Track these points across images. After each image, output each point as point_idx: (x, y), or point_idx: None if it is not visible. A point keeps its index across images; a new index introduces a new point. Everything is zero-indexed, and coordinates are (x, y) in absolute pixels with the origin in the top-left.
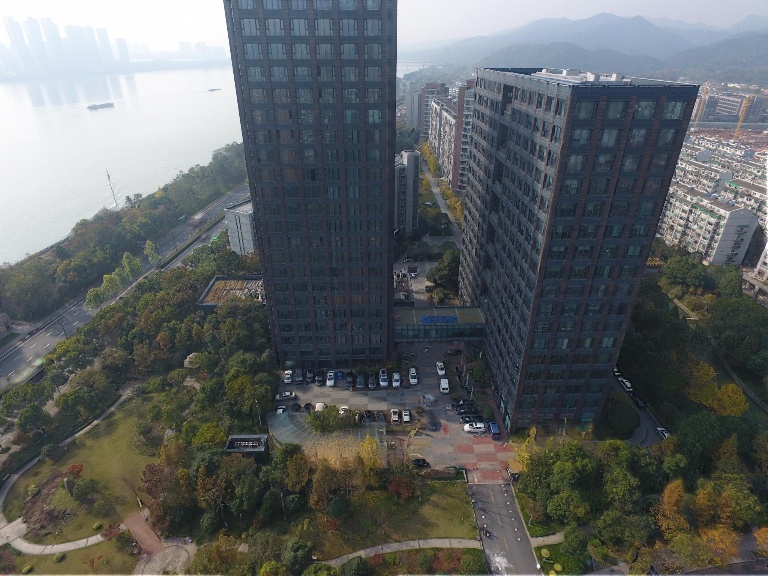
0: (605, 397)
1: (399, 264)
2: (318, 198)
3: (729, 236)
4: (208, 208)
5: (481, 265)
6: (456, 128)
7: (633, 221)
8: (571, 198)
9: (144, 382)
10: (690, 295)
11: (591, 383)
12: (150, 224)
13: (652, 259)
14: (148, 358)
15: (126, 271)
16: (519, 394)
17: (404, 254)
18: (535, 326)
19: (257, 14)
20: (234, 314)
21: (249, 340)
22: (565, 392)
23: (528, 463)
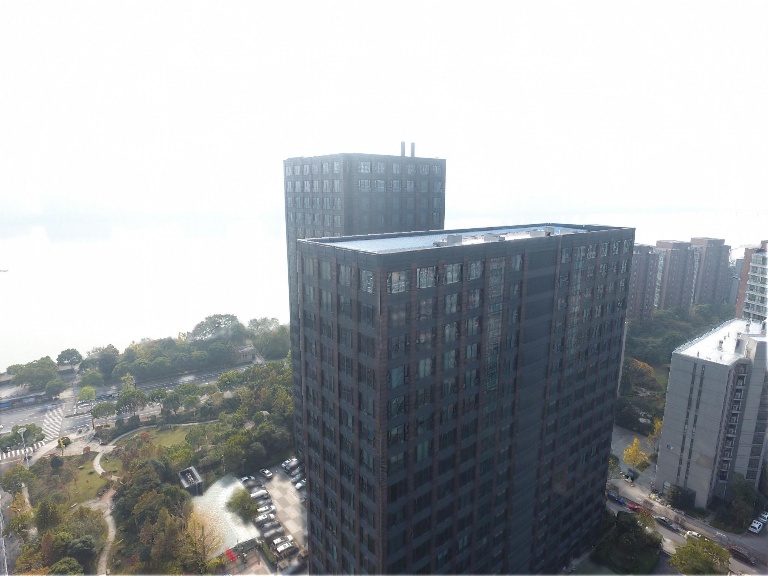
0: None
1: None
2: None
3: None
4: None
5: None
6: None
7: (360, 415)
8: None
9: None
10: None
11: None
12: None
13: None
14: (245, 400)
15: None
16: None
17: None
18: None
19: None
20: None
21: None
22: None
23: None
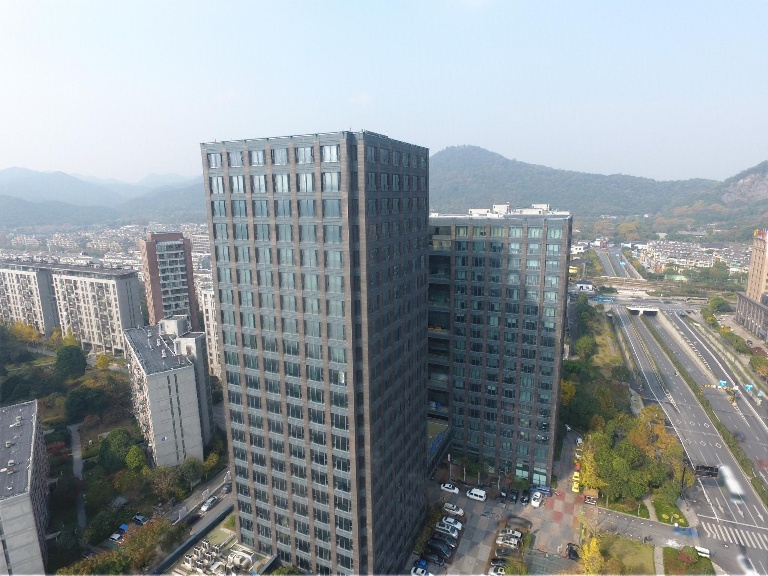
0: None
1: None
2: (400, 359)
3: None
4: None
5: None
6: (150, 286)
7: None
8: None
9: None
10: None
11: None
12: None
13: None
14: None
15: None
16: None
17: None
18: None
19: (377, 168)
20: None
21: None
22: None
23: (603, 480)
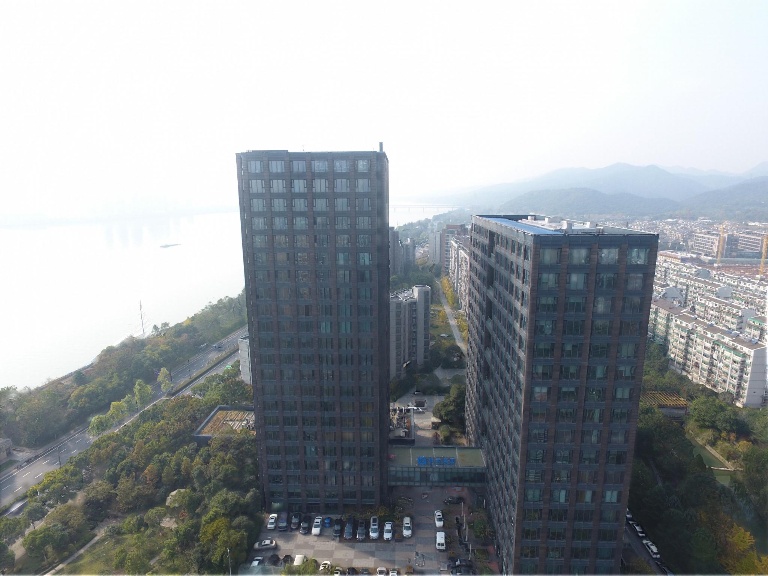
0: (619, 565)
1: (407, 397)
2: (311, 332)
3: (759, 376)
4: (230, 337)
5: (481, 402)
6: None
7: (616, 362)
8: (547, 338)
9: (122, 521)
10: (723, 441)
11: (600, 546)
12: (170, 352)
13: (676, 399)
14: (131, 493)
15: (135, 398)
16: (517, 556)
17: (414, 387)
18: (526, 474)
19: (263, 176)
20: (227, 447)
21: (237, 477)
22: (571, 556)
23: None
